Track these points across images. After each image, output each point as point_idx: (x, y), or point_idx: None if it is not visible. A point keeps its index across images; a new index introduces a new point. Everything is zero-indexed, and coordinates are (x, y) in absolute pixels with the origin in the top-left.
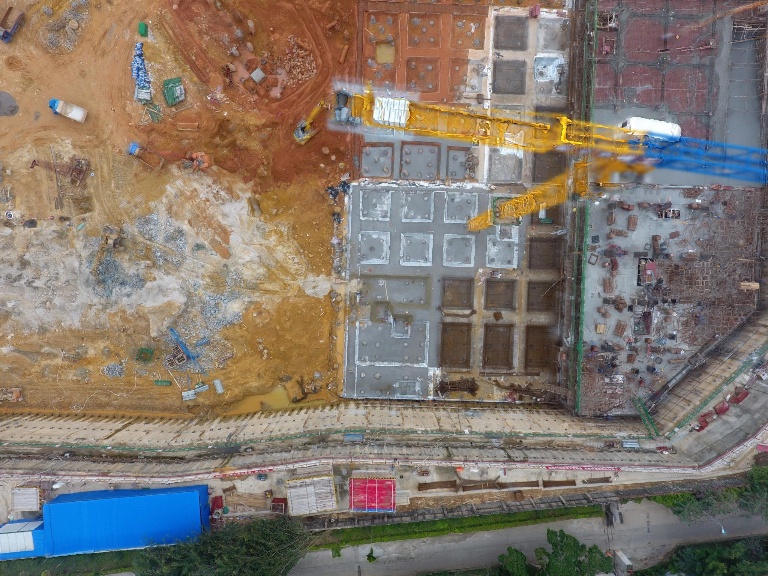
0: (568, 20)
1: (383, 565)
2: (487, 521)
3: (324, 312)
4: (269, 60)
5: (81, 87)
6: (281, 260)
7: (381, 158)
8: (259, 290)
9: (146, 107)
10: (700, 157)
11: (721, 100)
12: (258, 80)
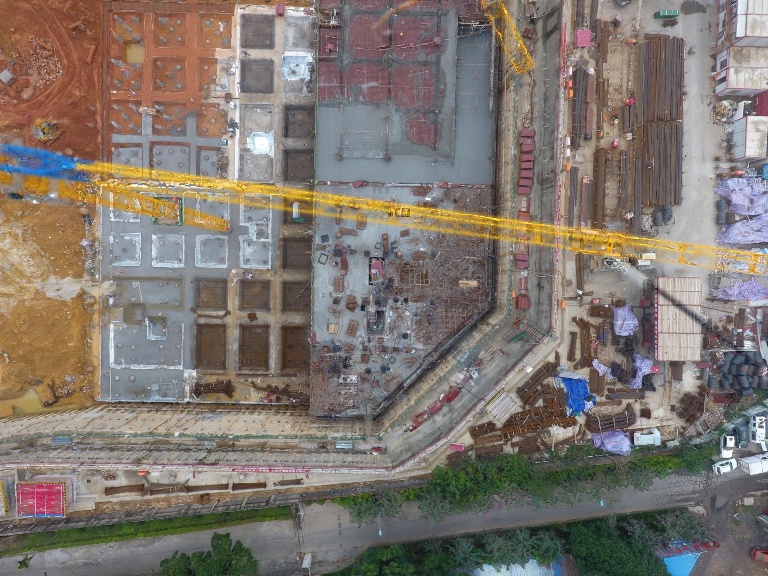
0: (316, 18)
1: (70, 571)
2: (174, 525)
3: (72, 315)
4: (19, 61)
5: None
6: (16, 263)
7: (131, 159)
8: None
9: None
10: (429, 155)
11: (448, 97)
12: (6, 81)
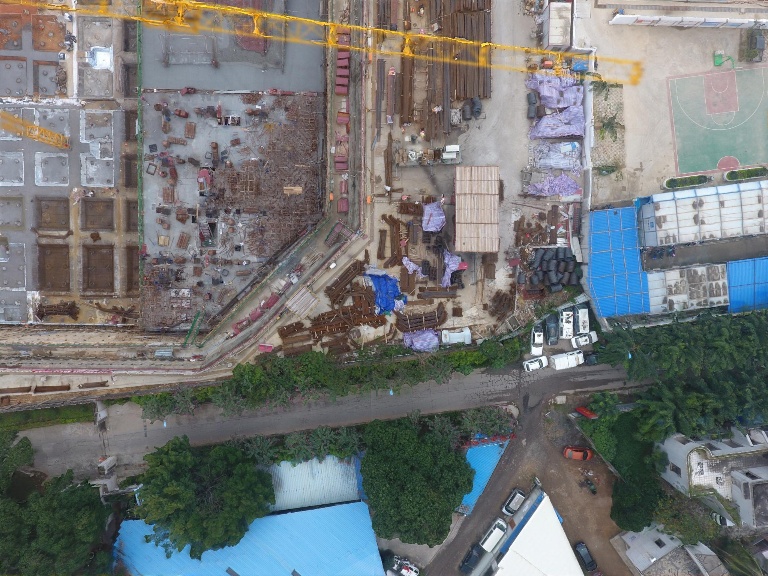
0: None
1: None
2: None
3: None
4: None
5: None
6: None
7: None
8: None
9: None
10: (258, 61)
11: (277, 1)
12: None
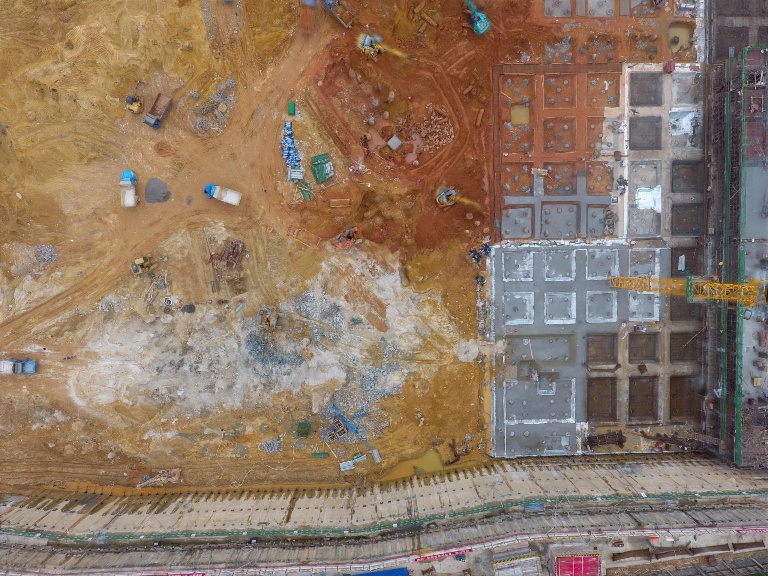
0: (700, 73)
1: None
2: None
3: (474, 375)
4: (404, 127)
5: (232, 169)
6: (436, 329)
7: (521, 219)
8: (416, 360)
9: (297, 186)
10: None
11: None
12: (395, 148)
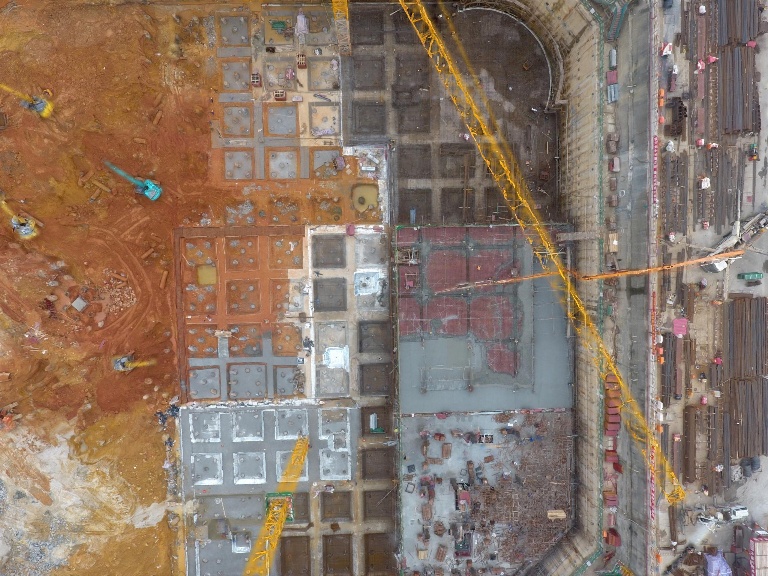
0: (385, 234)
1: None
2: None
3: (159, 539)
4: (91, 287)
5: None
6: (105, 501)
7: (209, 379)
8: (85, 531)
9: None
10: (509, 382)
11: (526, 326)
12: (79, 309)
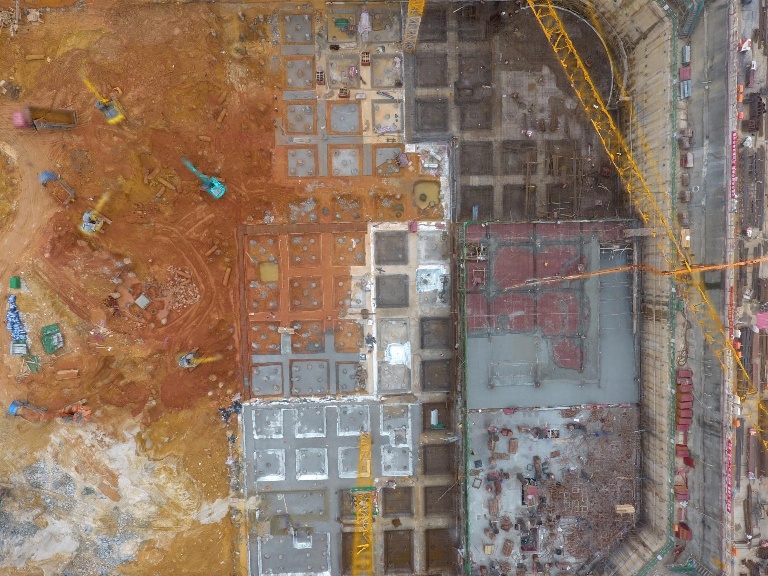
0: (447, 231)
1: None
2: None
3: (223, 534)
4: (153, 284)
5: None
6: (172, 497)
7: (271, 376)
8: (152, 527)
9: (24, 359)
10: (575, 378)
11: (593, 322)
12: (143, 307)
